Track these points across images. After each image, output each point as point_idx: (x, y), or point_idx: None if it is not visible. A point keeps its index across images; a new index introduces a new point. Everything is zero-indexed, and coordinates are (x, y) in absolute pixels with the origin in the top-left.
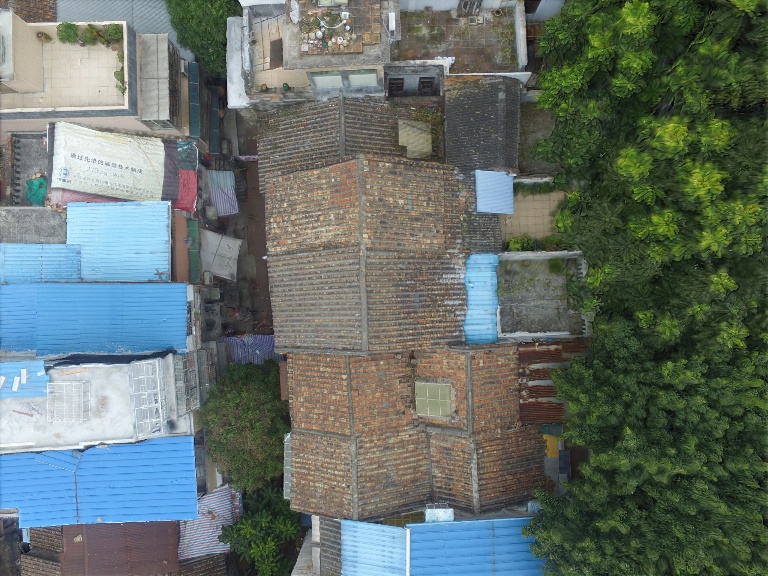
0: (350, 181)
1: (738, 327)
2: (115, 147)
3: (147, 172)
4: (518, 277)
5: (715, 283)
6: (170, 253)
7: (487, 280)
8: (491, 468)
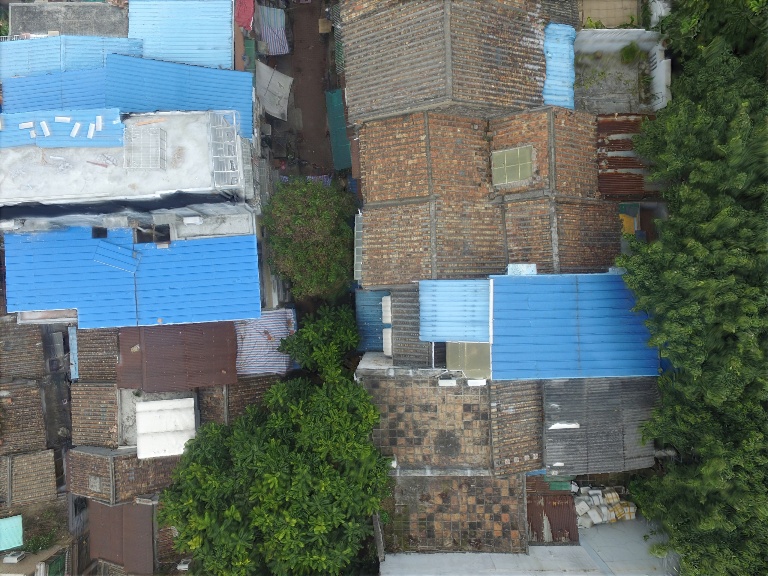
0: None
1: None
2: None
3: None
4: (589, 70)
5: None
6: (233, 50)
7: (565, 52)
8: (570, 236)
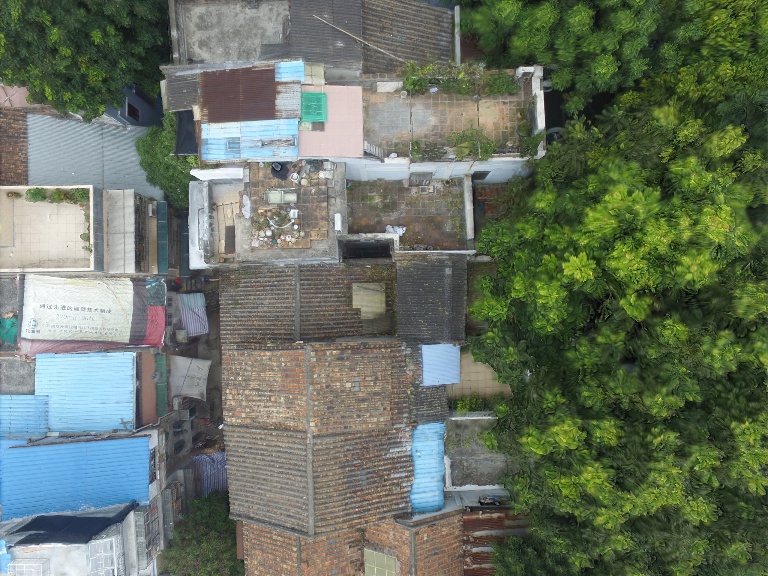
0: (299, 369)
1: (645, 569)
2: (84, 291)
3: (116, 311)
4: (468, 431)
5: (619, 540)
6: (135, 403)
7: (434, 448)
8: None
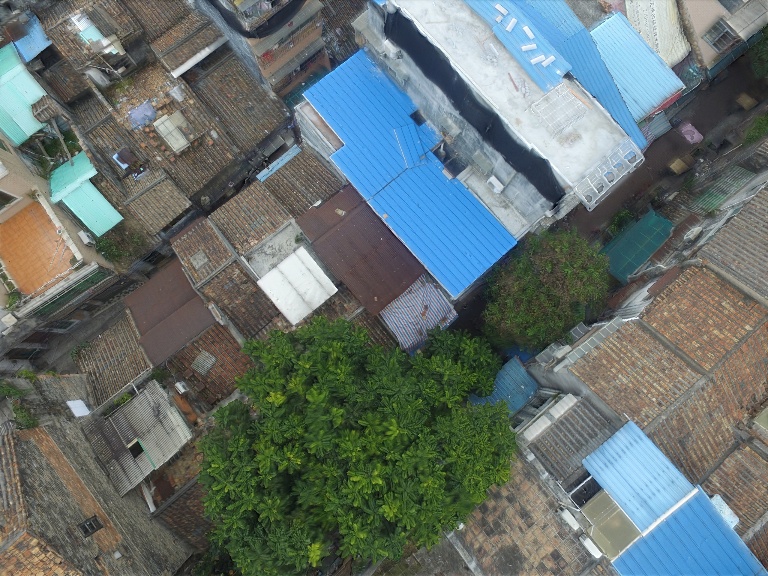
0: None
1: None
2: (669, 19)
3: None
4: None
5: None
6: (647, 116)
7: None
8: None
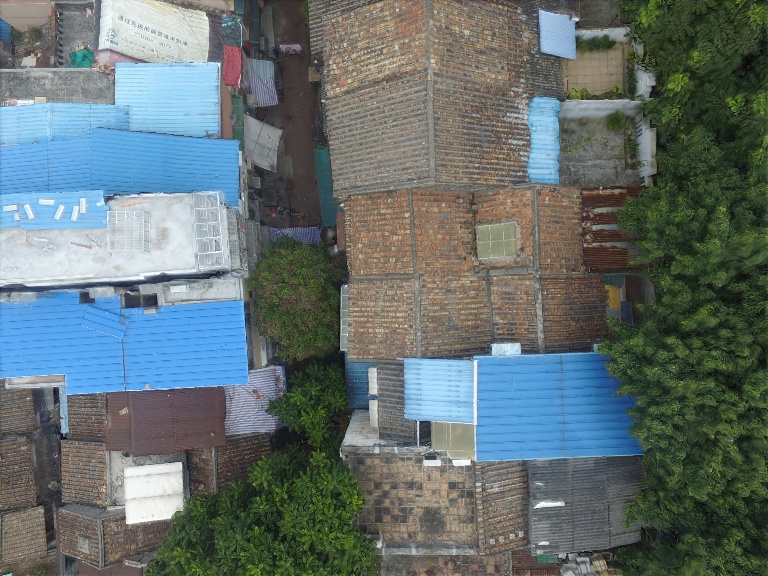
0: (416, 8)
1: None
2: (161, 16)
3: (192, 45)
4: (575, 136)
5: None
6: (220, 115)
7: (549, 125)
8: (555, 311)
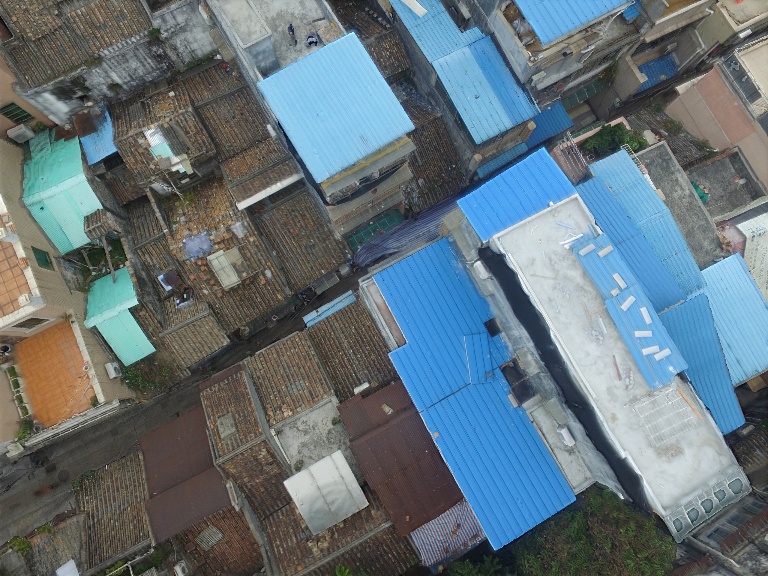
0: None
1: None
2: None
3: None
4: None
5: None
6: None
7: None
8: None
